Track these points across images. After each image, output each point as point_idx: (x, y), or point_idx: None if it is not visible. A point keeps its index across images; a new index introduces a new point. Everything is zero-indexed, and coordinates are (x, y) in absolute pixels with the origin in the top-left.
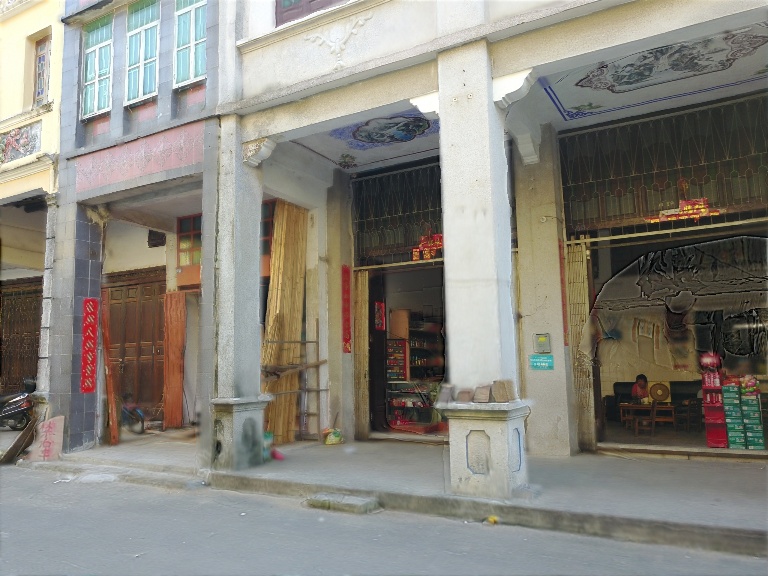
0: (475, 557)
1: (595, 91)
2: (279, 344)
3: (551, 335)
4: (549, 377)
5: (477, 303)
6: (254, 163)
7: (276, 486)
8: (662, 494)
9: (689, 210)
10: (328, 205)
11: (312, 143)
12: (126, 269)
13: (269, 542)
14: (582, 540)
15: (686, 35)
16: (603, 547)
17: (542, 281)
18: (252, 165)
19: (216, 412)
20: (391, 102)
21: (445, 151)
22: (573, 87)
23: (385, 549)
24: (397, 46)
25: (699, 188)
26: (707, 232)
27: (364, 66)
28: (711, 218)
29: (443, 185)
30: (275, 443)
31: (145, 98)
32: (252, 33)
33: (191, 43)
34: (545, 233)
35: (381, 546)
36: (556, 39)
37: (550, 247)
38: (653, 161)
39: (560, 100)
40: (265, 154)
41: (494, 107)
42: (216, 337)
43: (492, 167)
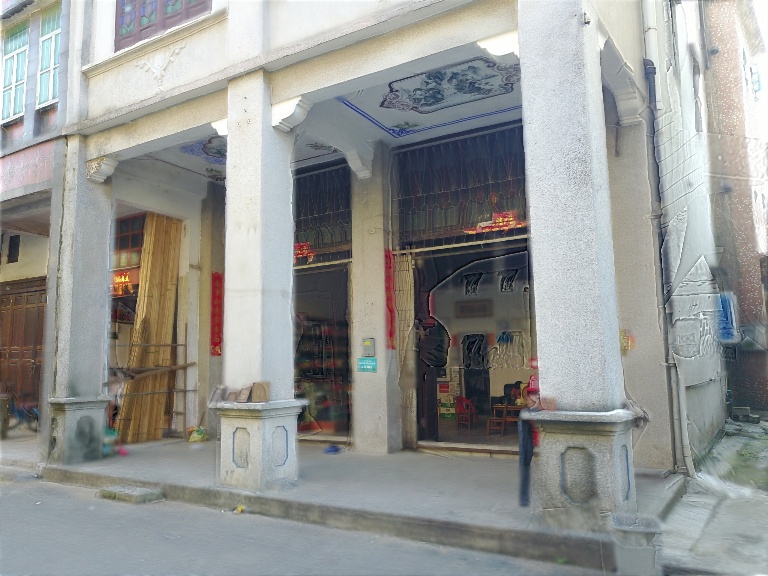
0: (184, 540)
1: (404, 112)
2: (143, 347)
3: (376, 340)
4: (373, 379)
5: (247, 311)
6: (98, 179)
7: (90, 479)
8: (410, 487)
9: (500, 222)
10: (202, 216)
11: (170, 159)
12: (38, 275)
13: (20, 526)
14: (301, 527)
15: (418, 67)
16: (311, 533)
17: (370, 289)
18: (97, 181)
19: (53, 410)
20: (197, 125)
21: (229, 172)
22: (381, 108)
23: (112, 533)
24: (203, 73)
25: (505, 202)
26: (513, 243)
27: (171, 92)
28: (514, 230)
29: (227, 203)
30: (139, 440)
31: (15, 118)
32: (97, 59)
33: (51, 67)
34: (374, 244)
35: (116, 530)
36: (318, 70)
37: (377, 257)
38: (474, 176)
39: (377, 120)
40: (107, 171)
41: (273, 131)
42: (56, 341)
43: (263, 187)
